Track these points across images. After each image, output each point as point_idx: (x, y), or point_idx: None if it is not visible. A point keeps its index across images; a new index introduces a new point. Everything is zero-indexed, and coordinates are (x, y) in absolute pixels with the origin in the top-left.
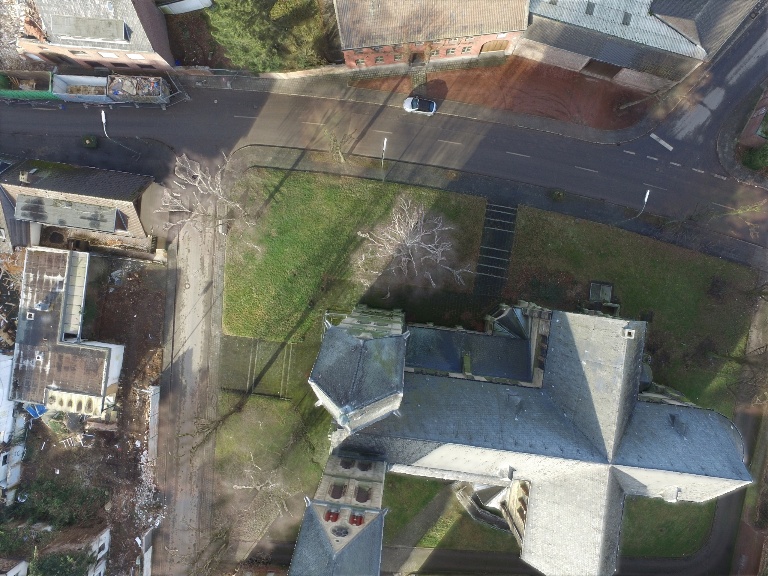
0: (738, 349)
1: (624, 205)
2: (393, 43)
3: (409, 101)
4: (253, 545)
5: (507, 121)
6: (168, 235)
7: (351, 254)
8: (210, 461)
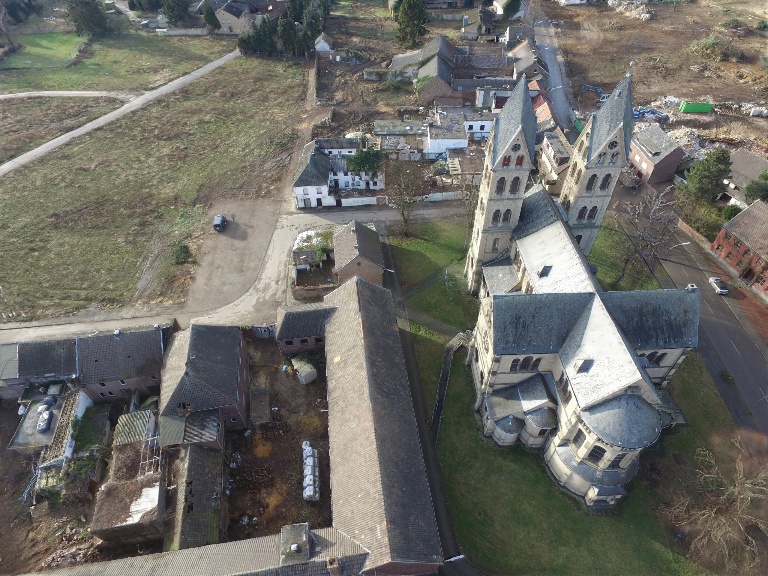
0: (708, 573)
1: (761, 433)
2: (748, 245)
3: (717, 278)
4: (387, 242)
5: (753, 337)
6: (555, 194)
7: (597, 262)
8: (434, 221)
